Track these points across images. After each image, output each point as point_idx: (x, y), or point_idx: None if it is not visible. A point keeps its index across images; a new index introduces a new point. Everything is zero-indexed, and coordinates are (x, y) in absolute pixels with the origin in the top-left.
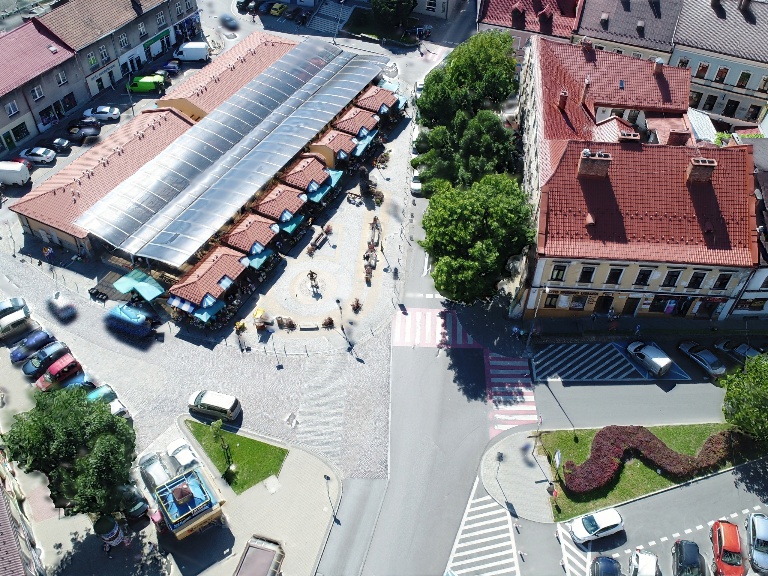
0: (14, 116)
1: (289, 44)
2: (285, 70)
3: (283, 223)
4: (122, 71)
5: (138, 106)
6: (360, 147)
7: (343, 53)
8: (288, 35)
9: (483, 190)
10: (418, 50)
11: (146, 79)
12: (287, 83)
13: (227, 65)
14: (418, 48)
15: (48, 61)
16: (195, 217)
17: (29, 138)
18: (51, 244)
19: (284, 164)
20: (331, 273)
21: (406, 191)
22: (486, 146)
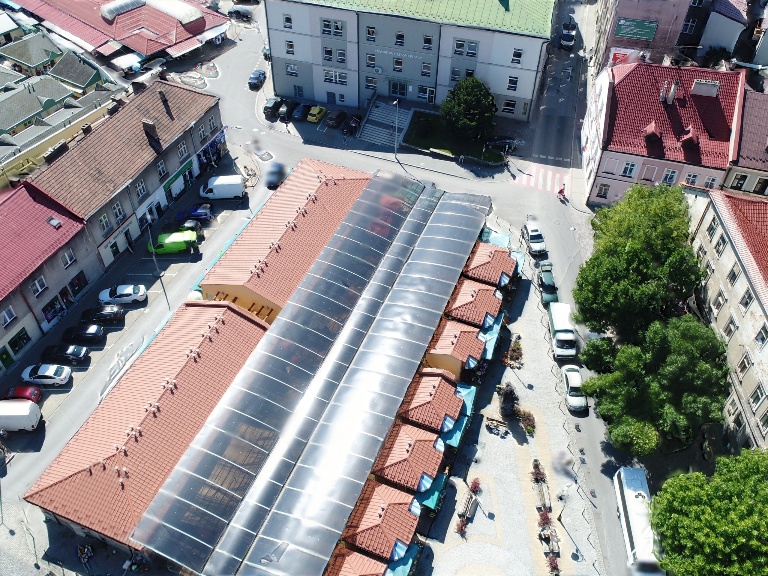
0: (10, 324)
1: (354, 179)
2: (363, 226)
3: (421, 493)
4: (140, 225)
5: (168, 276)
6: (489, 345)
7: (426, 190)
8: (336, 151)
9: (761, 494)
10: (507, 170)
11: (174, 237)
12: (370, 247)
13: (286, 223)
14: (506, 167)
15: (51, 242)
16: (301, 503)
17: (30, 344)
18: (88, 539)
19: (404, 394)
20: (500, 568)
21: (560, 407)
22: (705, 379)
